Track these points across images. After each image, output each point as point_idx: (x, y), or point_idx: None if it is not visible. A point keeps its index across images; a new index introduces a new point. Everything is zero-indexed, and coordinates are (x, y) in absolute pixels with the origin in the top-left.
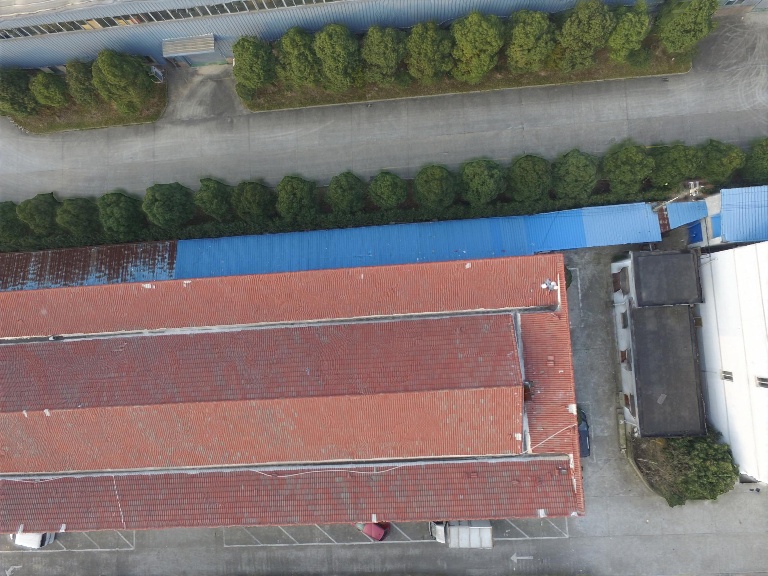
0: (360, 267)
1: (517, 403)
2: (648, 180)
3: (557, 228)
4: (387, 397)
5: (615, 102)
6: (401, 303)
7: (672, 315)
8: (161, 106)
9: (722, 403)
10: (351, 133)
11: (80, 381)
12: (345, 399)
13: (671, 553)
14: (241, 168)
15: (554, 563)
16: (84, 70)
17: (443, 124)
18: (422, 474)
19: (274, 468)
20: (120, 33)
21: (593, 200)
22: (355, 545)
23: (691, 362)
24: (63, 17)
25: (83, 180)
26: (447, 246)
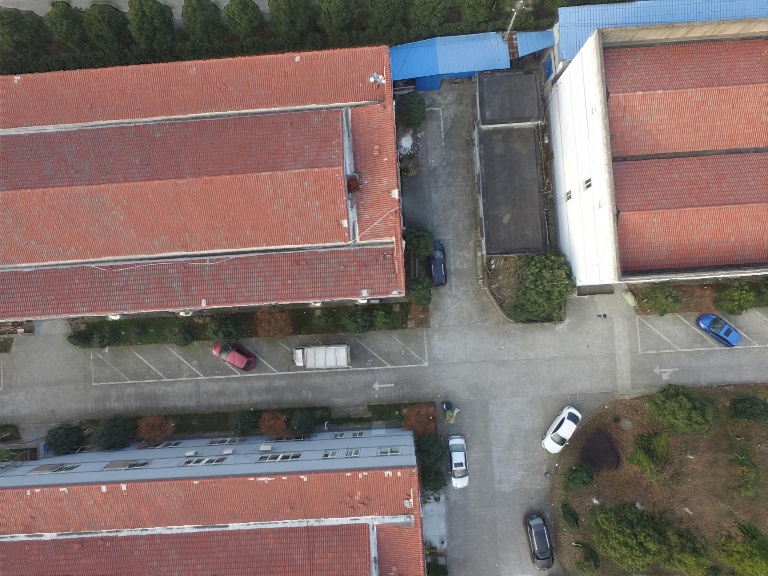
0: None
1: (340, 186)
2: (496, 6)
3: (412, 58)
4: (213, 181)
5: None
6: (234, 99)
7: (518, 139)
8: None
9: (566, 225)
10: None
11: None
12: (171, 184)
13: (524, 377)
14: None
15: (414, 390)
16: None
17: None
18: (253, 263)
19: (110, 263)
20: None
21: (446, 29)
22: (222, 379)
23: (535, 183)
24: None
25: None
26: None
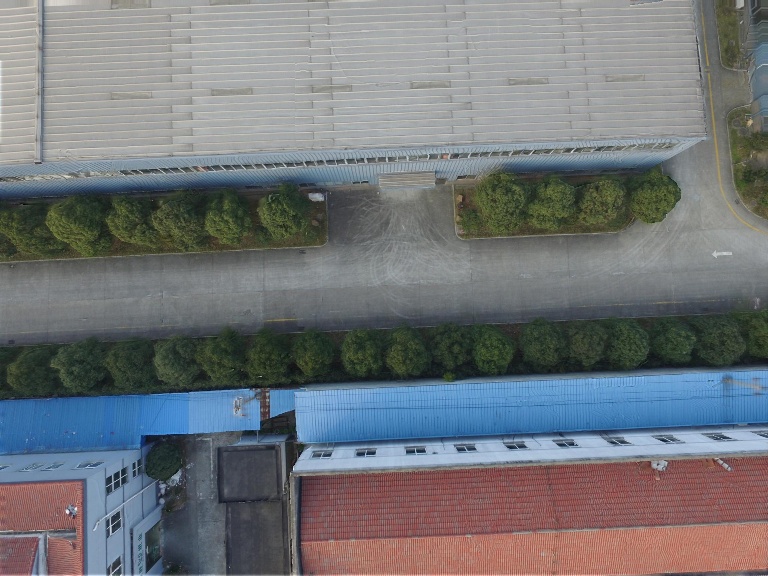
0: None
1: None
2: (245, 371)
3: (166, 411)
4: None
5: (253, 273)
6: None
7: (265, 505)
8: None
9: None
10: None
11: None
12: None
13: None
14: None
15: None
16: None
17: (84, 289)
18: None
19: None
20: None
21: (199, 385)
22: None
23: (280, 552)
24: None
25: None
26: (59, 426)
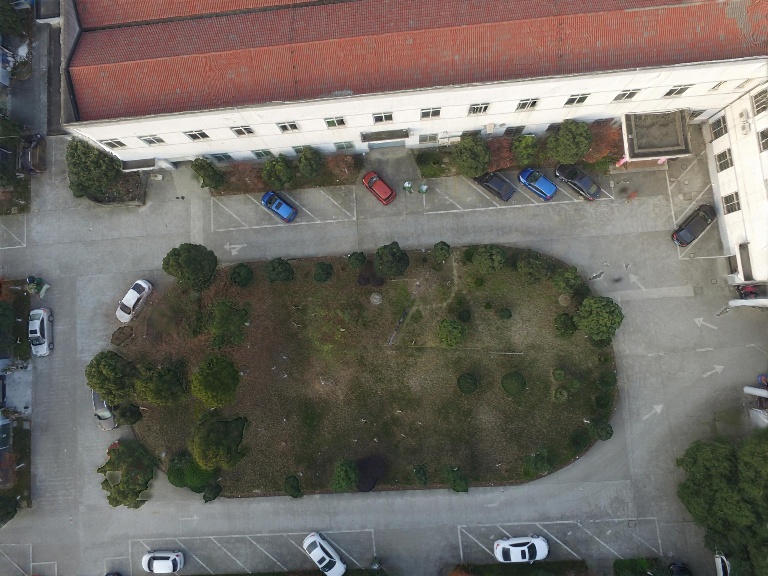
0: None
1: None
2: None
3: None
4: None
5: None
6: None
7: None
8: None
9: None
10: None
11: None
12: None
13: (108, 255)
14: None
15: (13, 269)
16: None
17: None
18: None
19: None
20: None
21: None
22: None
23: None
24: None
25: None
26: None
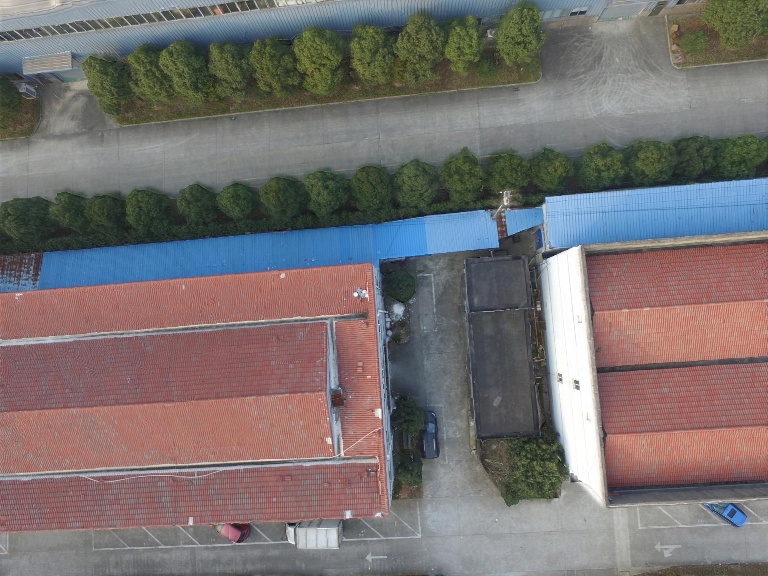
0: None
1: (323, 408)
2: (484, 188)
3: (402, 236)
4: (199, 404)
5: (468, 112)
6: (222, 312)
7: (508, 319)
8: (35, 121)
9: (558, 404)
10: (216, 145)
11: None
12: (160, 406)
13: (519, 551)
14: (110, 181)
15: (407, 562)
16: None
17: (303, 135)
18: (240, 478)
19: (102, 474)
20: None
21: (435, 208)
22: (217, 547)
23: (526, 365)
24: None
25: None
26: (297, 255)
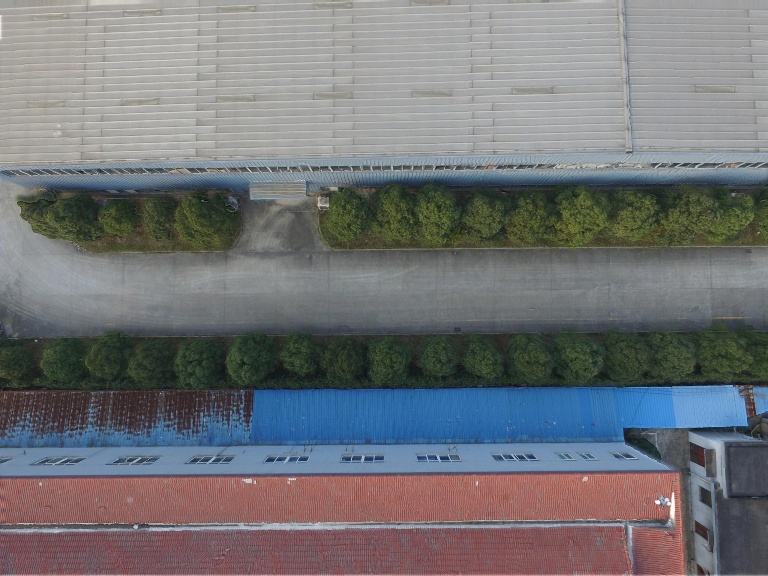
0: (476, 475)
1: None
2: None
3: (647, 405)
4: None
5: (700, 270)
6: (513, 510)
7: (754, 501)
8: (235, 235)
9: None
10: (436, 280)
11: (166, 573)
12: None
13: None
14: (319, 309)
15: None
16: (166, 213)
17: (530, 279)
18: None
19: None
20: (208, 177)
21: (683, 380)
22: None
23: None
24: (153, 166)
25: (146, 308)
26: (537, 416)
